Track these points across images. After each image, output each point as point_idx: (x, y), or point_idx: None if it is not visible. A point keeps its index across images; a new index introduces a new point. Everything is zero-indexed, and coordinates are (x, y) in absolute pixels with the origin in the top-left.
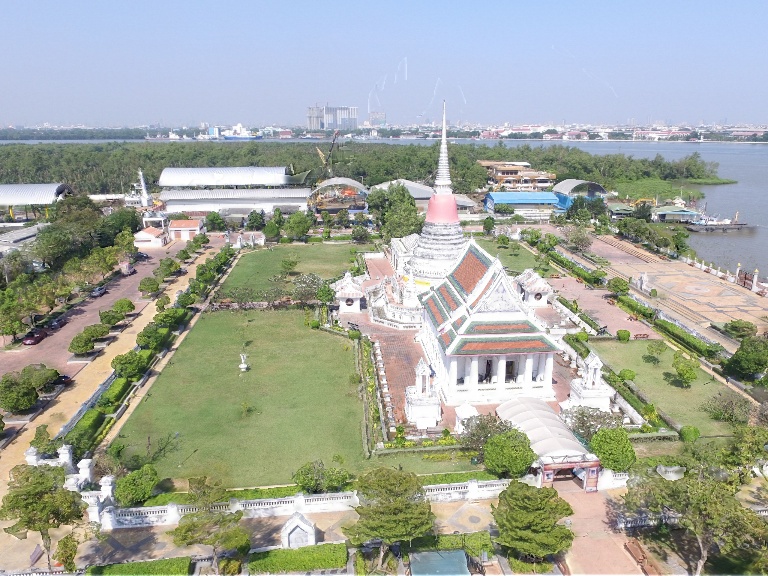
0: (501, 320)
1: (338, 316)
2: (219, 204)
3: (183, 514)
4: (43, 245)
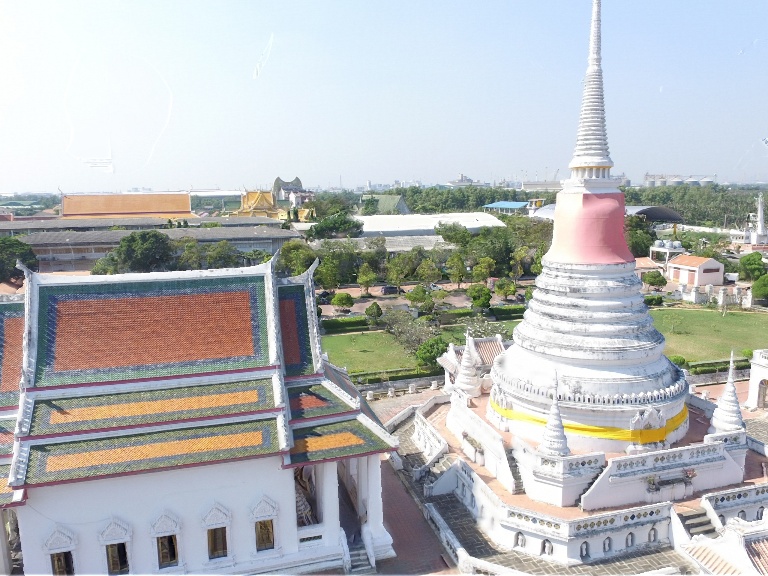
0: None
1: (429, 391)
2: None
3: None
4: (458, 247)
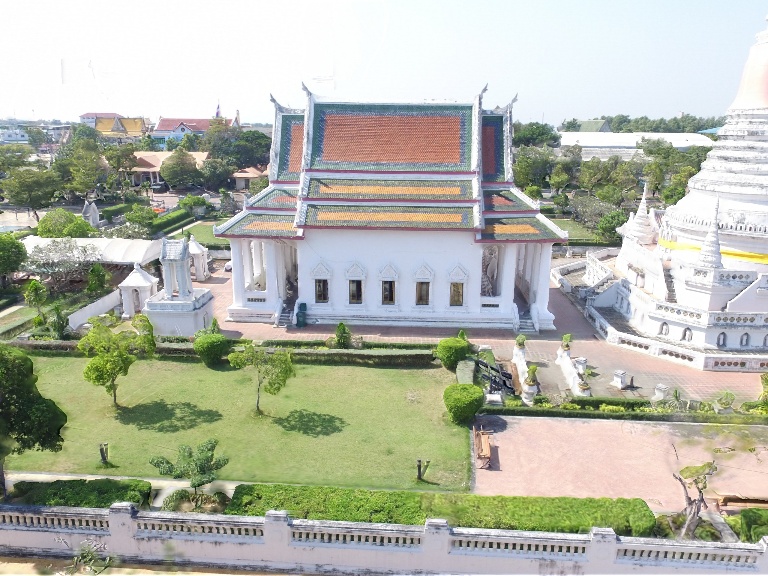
0: None
1: None
2: None
3: None
4: (659, 159)
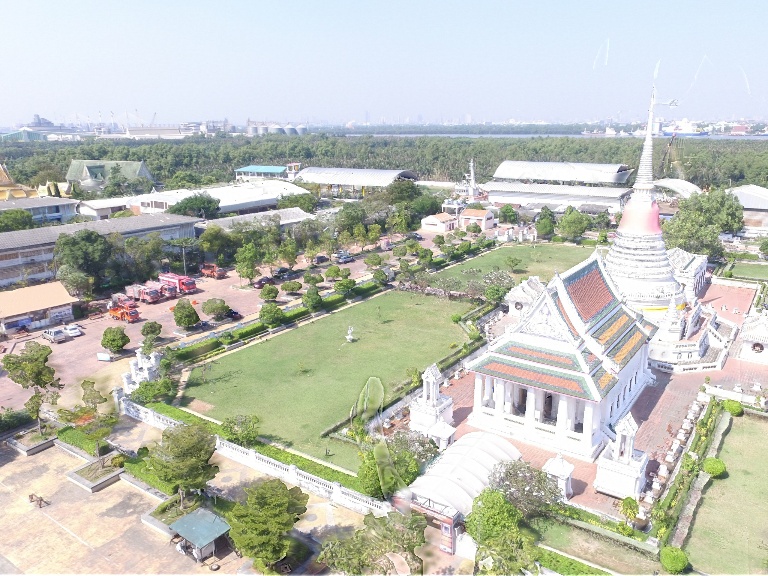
0: (544, 347)
1: (502, 318)
2: (535, 198)
3: (157, 420)
4: (334, 217)
